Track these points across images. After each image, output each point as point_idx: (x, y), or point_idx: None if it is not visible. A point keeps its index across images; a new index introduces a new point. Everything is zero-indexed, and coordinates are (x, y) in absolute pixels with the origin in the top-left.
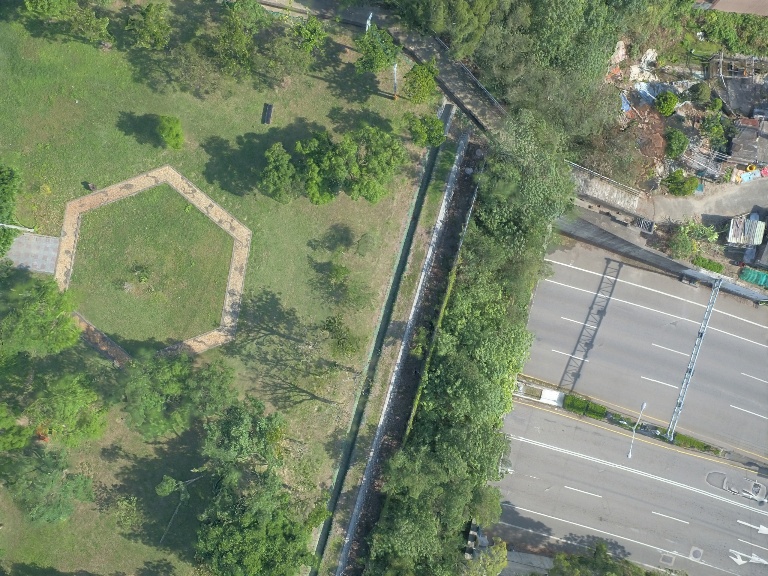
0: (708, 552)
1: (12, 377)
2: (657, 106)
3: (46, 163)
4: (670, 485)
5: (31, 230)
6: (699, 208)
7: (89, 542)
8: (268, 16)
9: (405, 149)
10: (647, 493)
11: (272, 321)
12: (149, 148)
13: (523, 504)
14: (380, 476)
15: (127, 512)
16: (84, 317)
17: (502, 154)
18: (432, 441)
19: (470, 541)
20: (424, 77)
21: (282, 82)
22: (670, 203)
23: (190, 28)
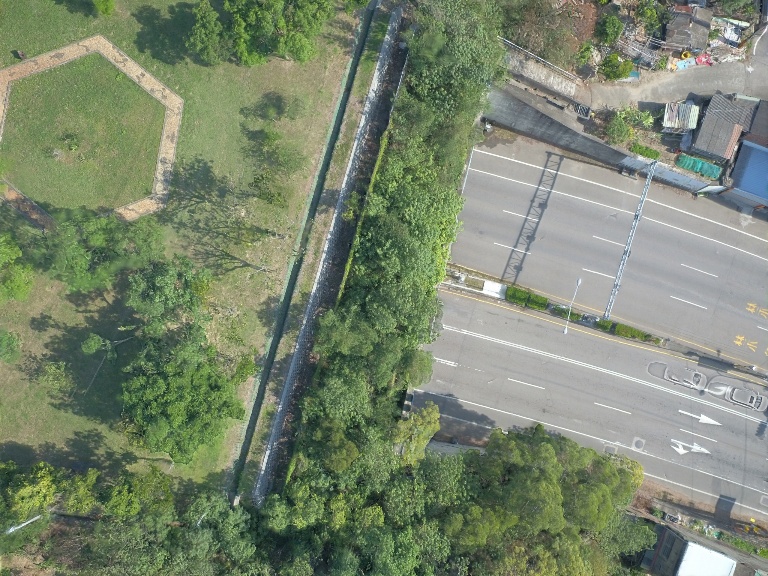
0: (650, 442)
1: None
2: None
3: None
4: (612, 376)
5: None
6: (635, 95)
7: (18, 412)
8: None
9: (331, 5)
10: (589, 384)
11: (204, 189)
12: (80, 17)
13: (467, 397)
14: None
15: (56, 377)
16: (13, 185)
17: None
18: (363, 303)
19: (405, 411)
20: None
21: None
22: (607, 91)
23: None
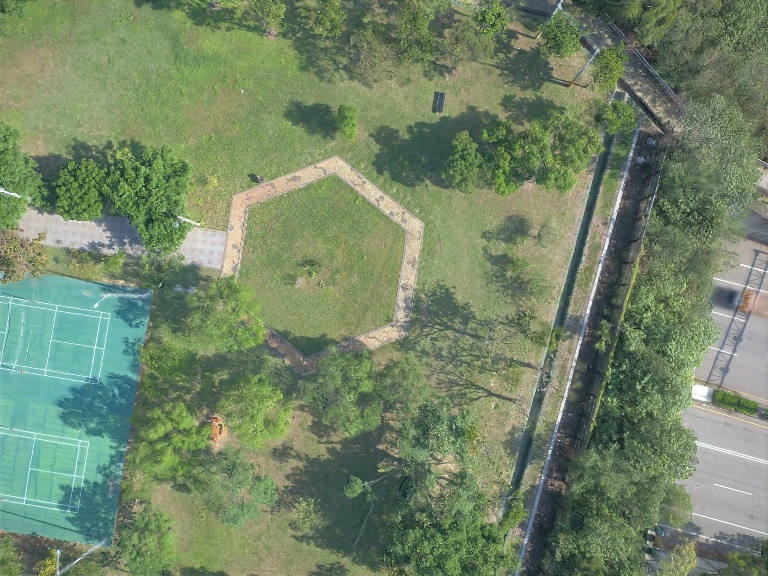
0: None
1: (179, 376)
2: None
3: (211, 155)
4: None
5: (198, 224)
6: None
7: (260, 545)
8: (446, 1)
9: (599, 136)
10: None
11: (446, 316)
12: (317, 139)
13: None
14: (553, 475)
15: (304, 514)
16: (253, 313)
17: (702, 141)
18: (619, 438)
19: (648, 541)
20: (614, 62)
21: (453, 70)
22: None
23: (357, 15)
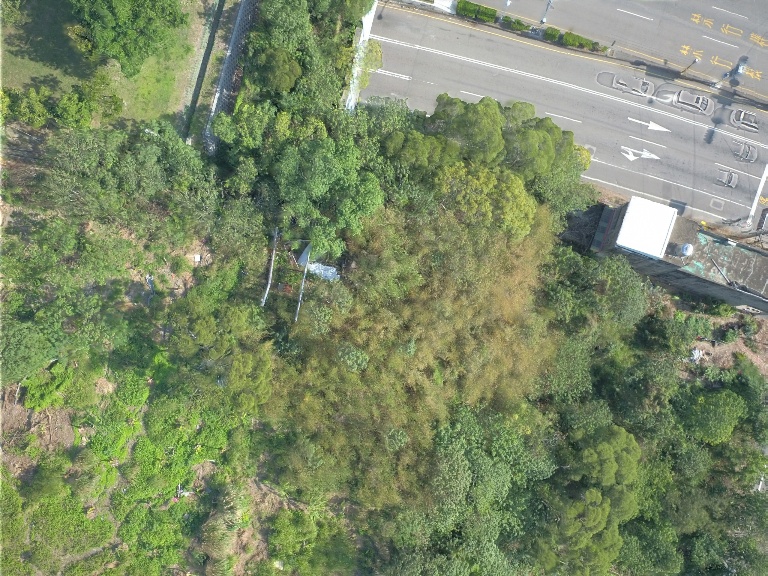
0: (601, 149)
1: None
2: None
3: None
4: (562, 86)
5: None
6: None
7: None
8: None
9: None
10: (540, 95)
11: None
12: None
13: (421, 109)
14: None
15: (11, 14)
16: None
17: None
18: None
19: None
20: None
21: None
22: None
23: None
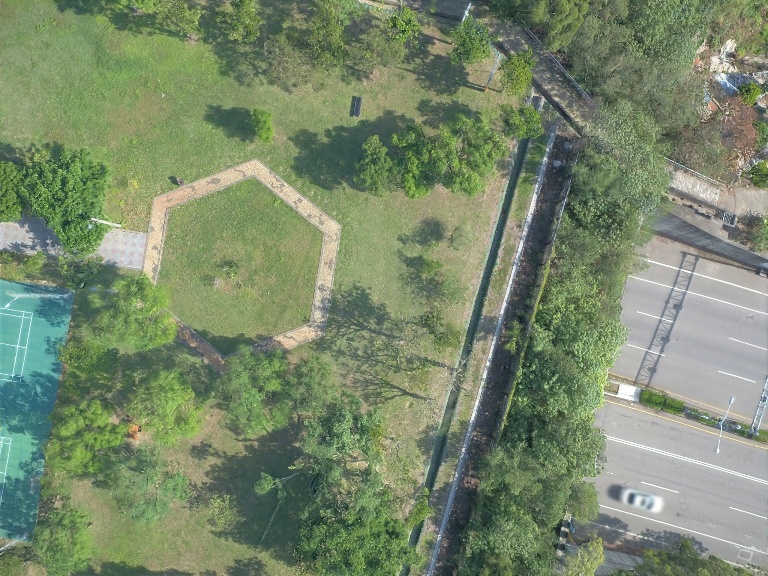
0: None
1: (100, 374)
2: (739, 97)
3: (132, 158)
4: (748, 480)
5: (118, 226)
6: None
7: (179, 540)
8: (360, 7)
9: (505, 141)
10: (725, 488)
11: (362, 316)
12: (236, 142)
13: (599, 500)
14: (469, 472)
15: (220, 510)
16: (172, 313)
17: None
18: (528, 437)
19: (562, 537)
20: (522, 68)
21: (370, 74)
22: (751, 195)
23: (277, 20)
